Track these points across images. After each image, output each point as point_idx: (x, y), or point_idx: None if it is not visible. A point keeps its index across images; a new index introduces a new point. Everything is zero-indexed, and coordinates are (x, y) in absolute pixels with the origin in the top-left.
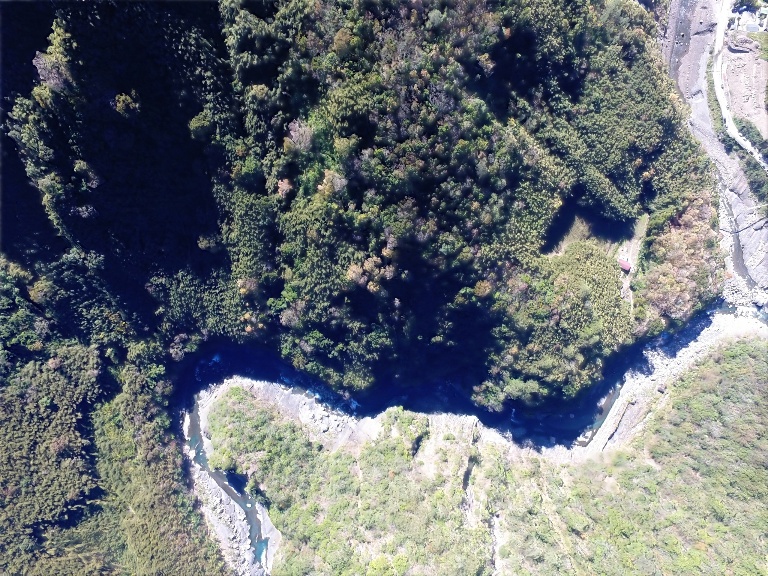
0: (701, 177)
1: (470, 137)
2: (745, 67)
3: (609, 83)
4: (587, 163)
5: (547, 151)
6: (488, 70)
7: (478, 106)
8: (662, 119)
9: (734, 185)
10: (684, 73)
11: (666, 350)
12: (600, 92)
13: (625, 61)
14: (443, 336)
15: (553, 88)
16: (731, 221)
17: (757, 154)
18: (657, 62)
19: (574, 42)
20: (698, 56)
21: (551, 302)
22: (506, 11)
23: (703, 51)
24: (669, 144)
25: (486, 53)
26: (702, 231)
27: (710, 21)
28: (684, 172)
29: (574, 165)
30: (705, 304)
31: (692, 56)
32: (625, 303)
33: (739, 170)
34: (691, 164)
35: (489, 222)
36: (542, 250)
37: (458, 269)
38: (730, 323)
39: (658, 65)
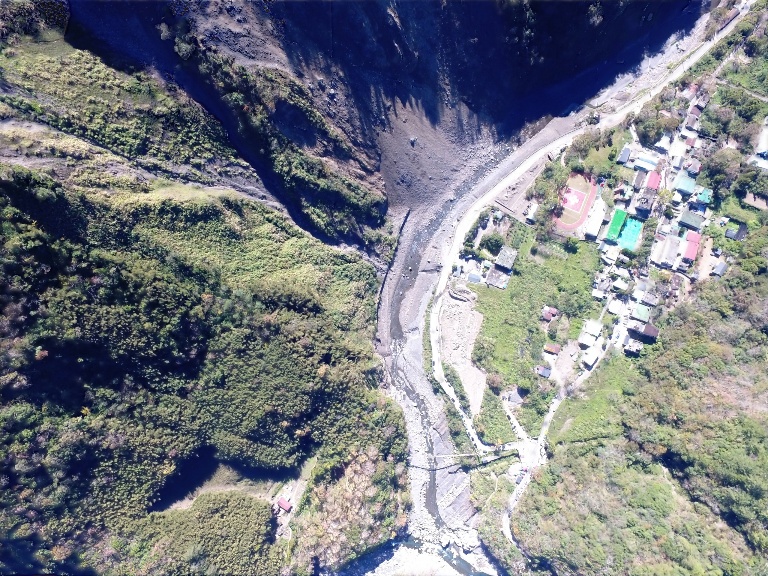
0: (371, 433)
1: (0, 444)
2: (460, 315)
3: (236, 361)
4: (215, 428)
5: (151, 425)
6: (23, 384)
7: (9, 417)
8: (306, 391)
9: (437, 425)
10: (406, 307)
11: (343, 575)
12: (225, 368)
13: (261, 339)
14: (53, 569)
15: (149, 375)
16: (430, 458)
17: (458, 402)
18: (301, 340)
19: (174, 335)
20: (421, 294)
21: (143, 568)
22: (41, 334)
23: (427, 289)
24: (330, 404)
25: (16, 371)
26: (360, 488)
27: (437, 262)
28: (353, 426)
29: (193, 433)
30: (364, 552)
31: (415, 292)
32: (283, 540)
33: (443, 412)
34: (360, 420)
35: (53, 503)
36: (168, 499)
37: (24, 538)
38: (411, 559)
39: (301, 343)
